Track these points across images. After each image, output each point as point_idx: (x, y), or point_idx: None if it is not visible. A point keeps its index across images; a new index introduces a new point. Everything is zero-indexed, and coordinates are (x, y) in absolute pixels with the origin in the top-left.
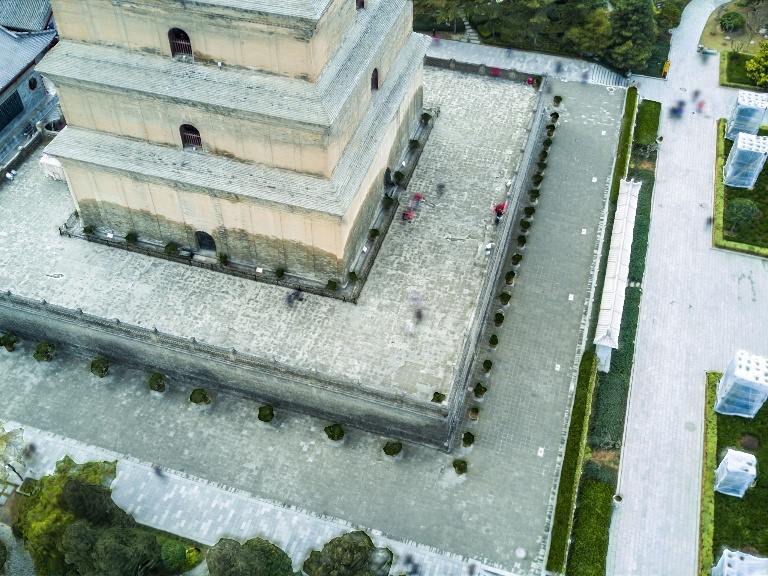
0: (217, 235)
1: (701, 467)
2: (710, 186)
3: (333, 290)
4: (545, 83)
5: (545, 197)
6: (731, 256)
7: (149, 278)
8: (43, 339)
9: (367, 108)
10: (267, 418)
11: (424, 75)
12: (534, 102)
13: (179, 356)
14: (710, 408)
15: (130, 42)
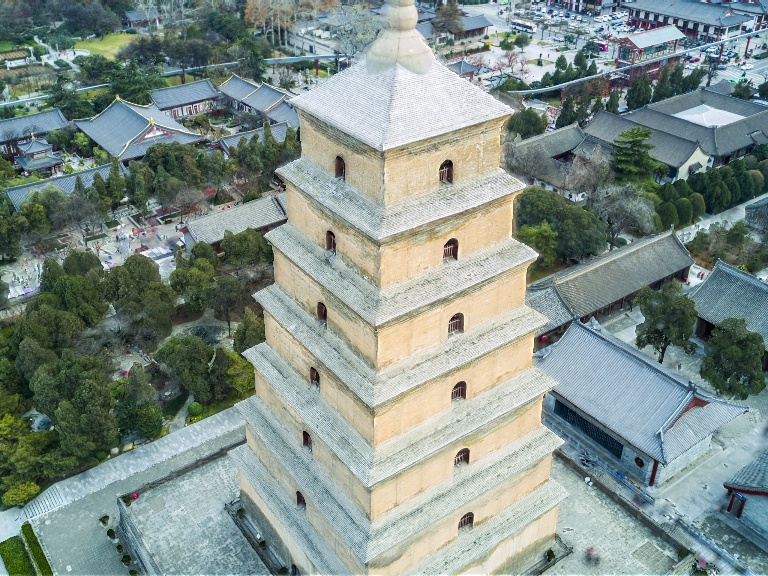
0: None
1: None
2: None
3: None
4: None
5: None
6: None
7: None
8: None
9: None
10: None
11: None
12: None
13: None
14: None
15: None
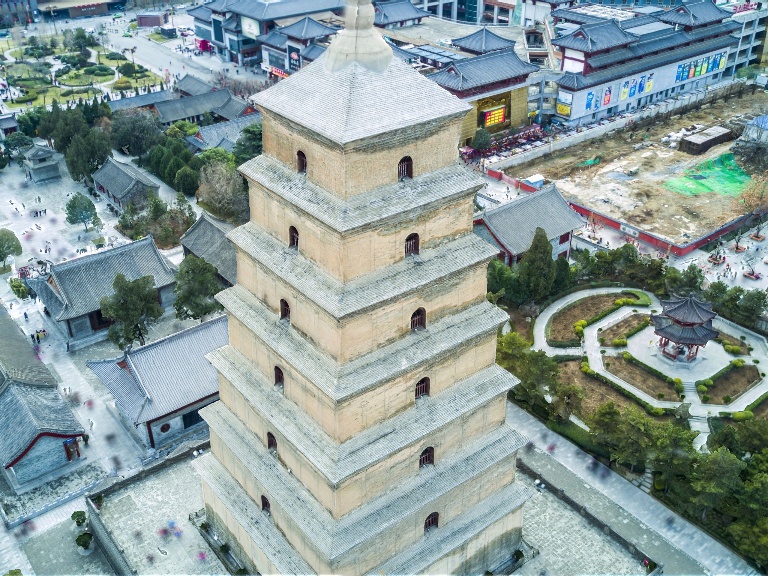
0: None
1: None
2: None
3: None
4: (660, 573)
5: None
6: None
7: None
8: None
9: (414, 542)
10: None
11: (553, 509)
12: None
13: None
14: None
15: (250, 425)
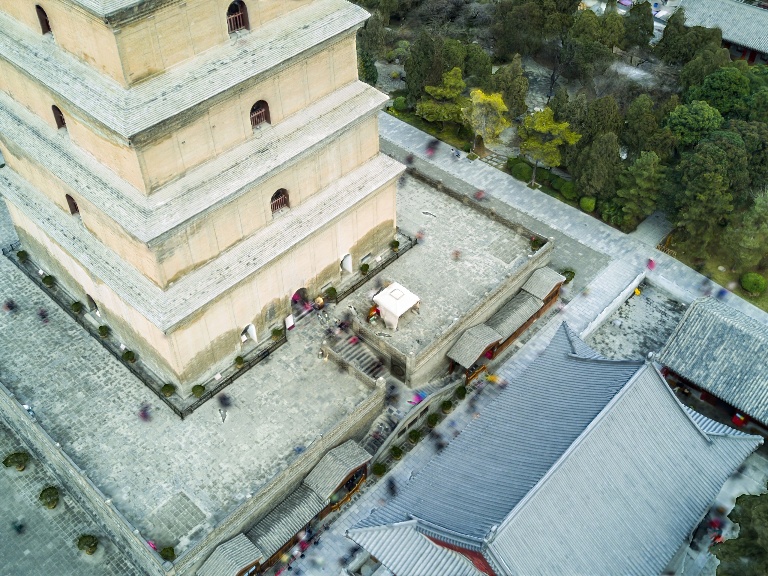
0: None
1: None
2: None
3: None
4: None
5: None
6: None
7: None
8: None
9: None
10: None
11: None
12: None
13: None
14: None
15: None
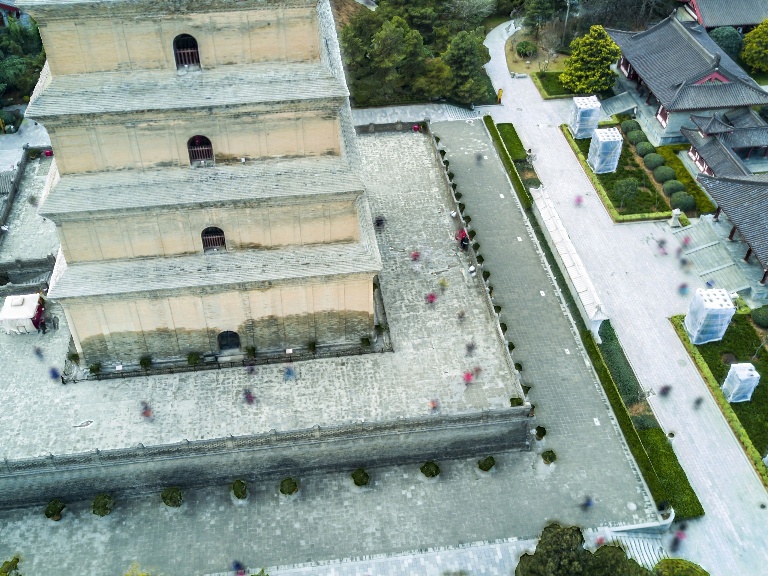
0: (243, 330)
1: (708, 390)
2: (585, 178)
3: (369, 346)
4: None
5: (473, 221)
6: (631, 226)
7: (185, 394)
8: (91, 494)
9: None
10: (364, 481)
11: None
12: (429, 144)
13: (257, 455)
14: (688, 343)
15: (143, 161)
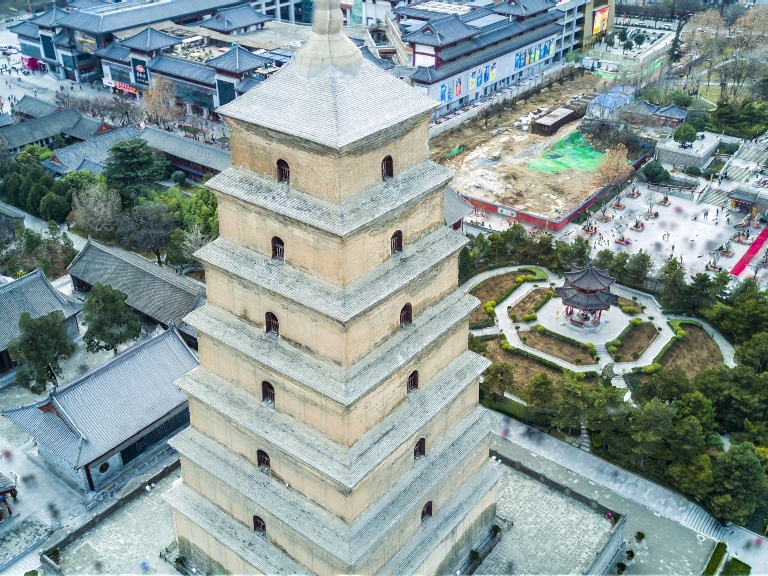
0: None
1: None
2: None
3: None
4: (623, 522)
5: None
6: None
7: None
8: None
9: (414, 533)
10: None
11: (514, 481)
12: None
13: None
14: None
15: (233, 446)
